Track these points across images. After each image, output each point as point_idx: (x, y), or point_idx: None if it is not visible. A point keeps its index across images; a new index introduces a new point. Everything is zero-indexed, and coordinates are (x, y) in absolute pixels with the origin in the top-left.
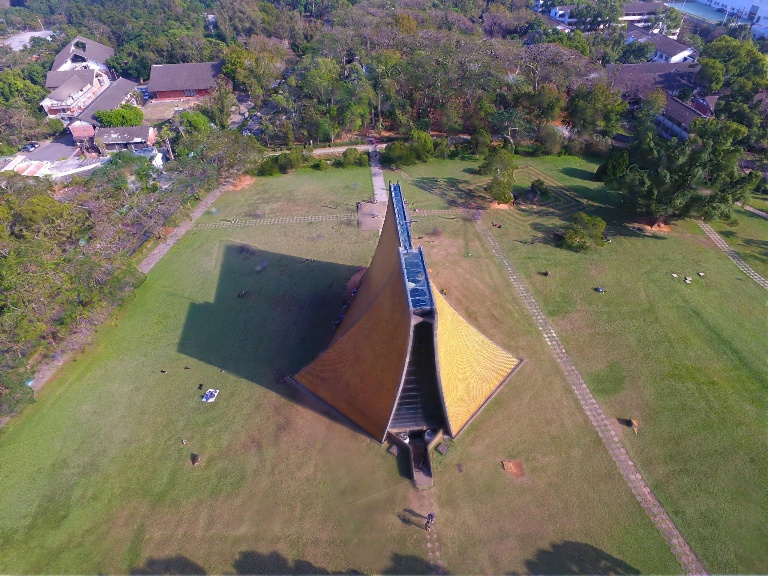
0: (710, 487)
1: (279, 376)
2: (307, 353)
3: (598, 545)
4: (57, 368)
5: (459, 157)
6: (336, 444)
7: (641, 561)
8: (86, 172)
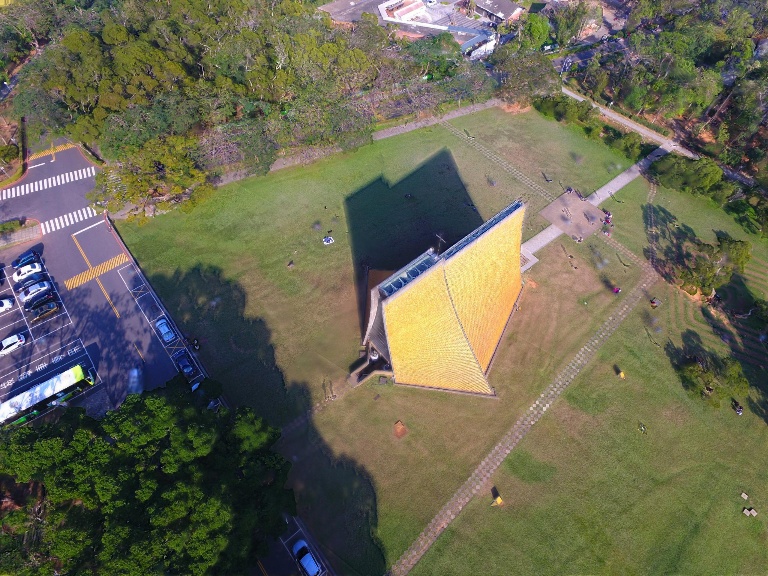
0: (479, 573)
1: (365, 262)
2: (392, 264)
3: (379, 501)
4: (293, 164)
5: (739, 216)
6: (345, 322)
7: (385, 532)
8: (414, 38)
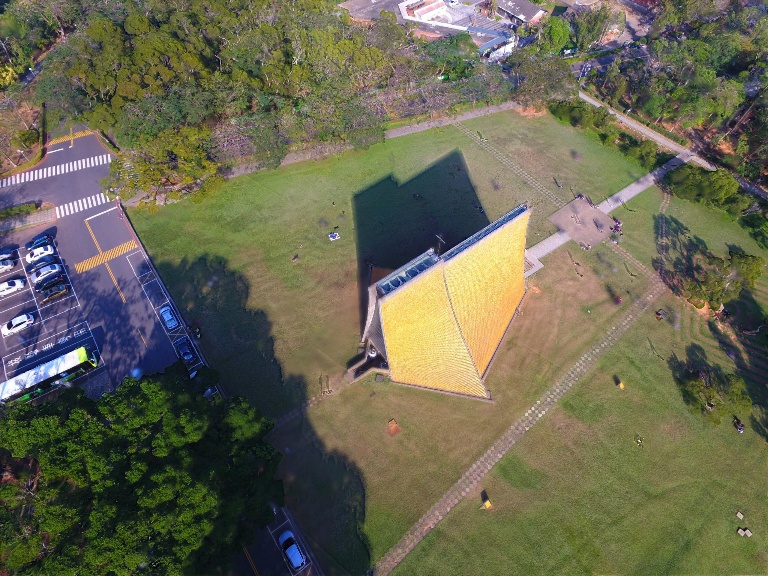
0: (463, 575)
1: (369, 259)
2: (396, 262)
3: (367, 498)
4: (304, 159)
5: (754, 230)
6: (345, 318)
7: (371, 528)
8: (432, 38)
